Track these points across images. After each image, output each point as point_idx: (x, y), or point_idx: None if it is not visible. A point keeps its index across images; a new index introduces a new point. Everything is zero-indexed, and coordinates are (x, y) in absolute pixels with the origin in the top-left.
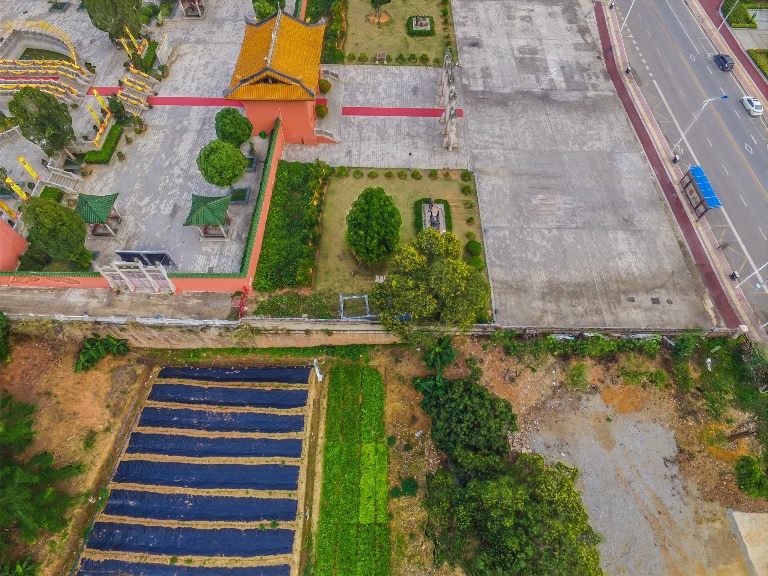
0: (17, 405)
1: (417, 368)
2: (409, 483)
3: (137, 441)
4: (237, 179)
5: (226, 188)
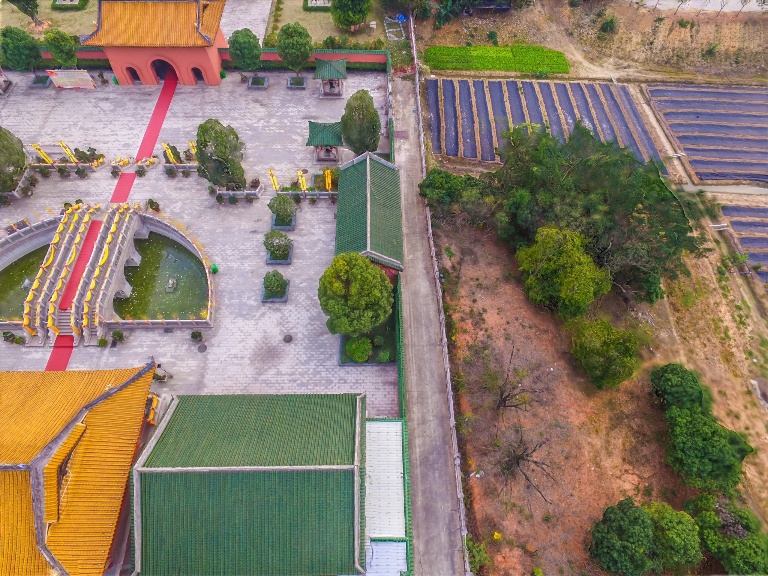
0: (497, 150)
1: (427, 28)
2: (492, 34)
3: (486, 156)
4: (276, 87)
5: (286, 91)
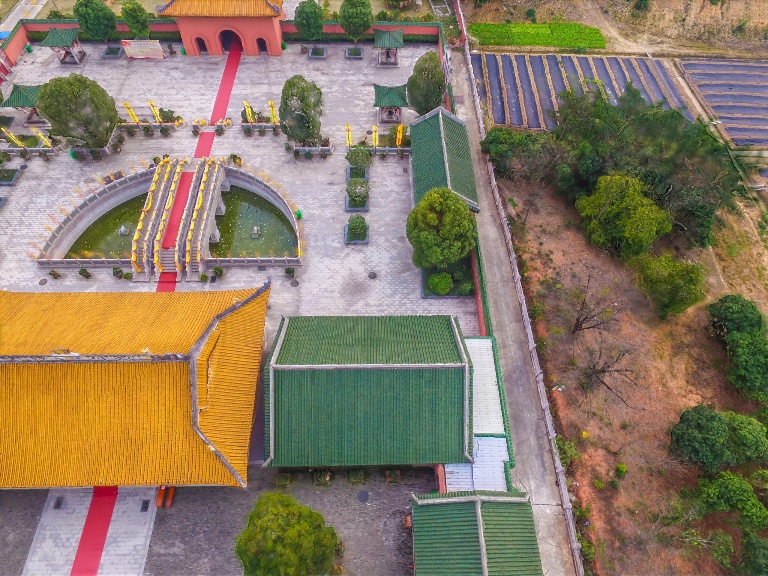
0: (550, 112)
1: (469, 6)
2: (530, 11)
3: (532, 124)
4: (334, 57)
5: (345, 61)
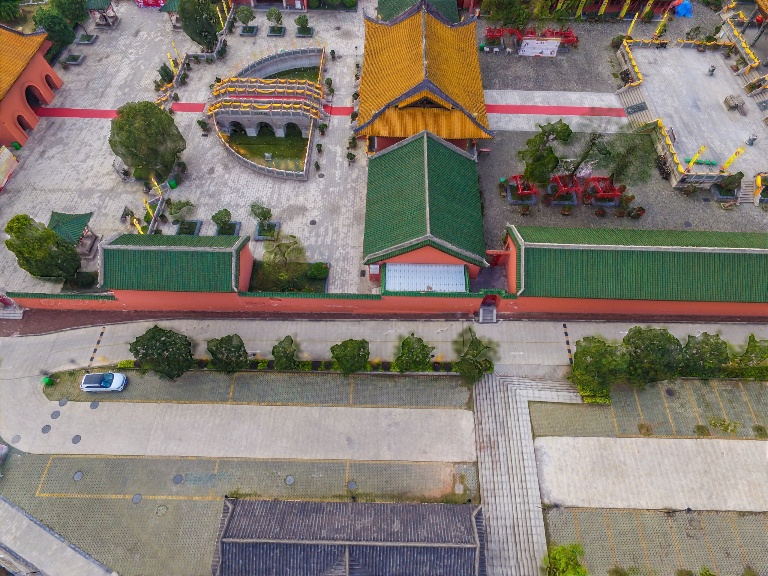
0: None
1: None
2: None
3: None
4: (85, 51)
5: (96, 45)
